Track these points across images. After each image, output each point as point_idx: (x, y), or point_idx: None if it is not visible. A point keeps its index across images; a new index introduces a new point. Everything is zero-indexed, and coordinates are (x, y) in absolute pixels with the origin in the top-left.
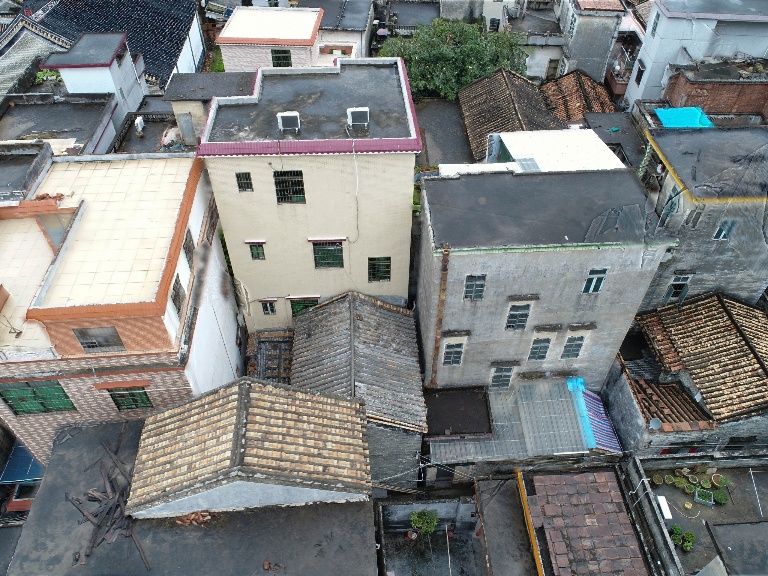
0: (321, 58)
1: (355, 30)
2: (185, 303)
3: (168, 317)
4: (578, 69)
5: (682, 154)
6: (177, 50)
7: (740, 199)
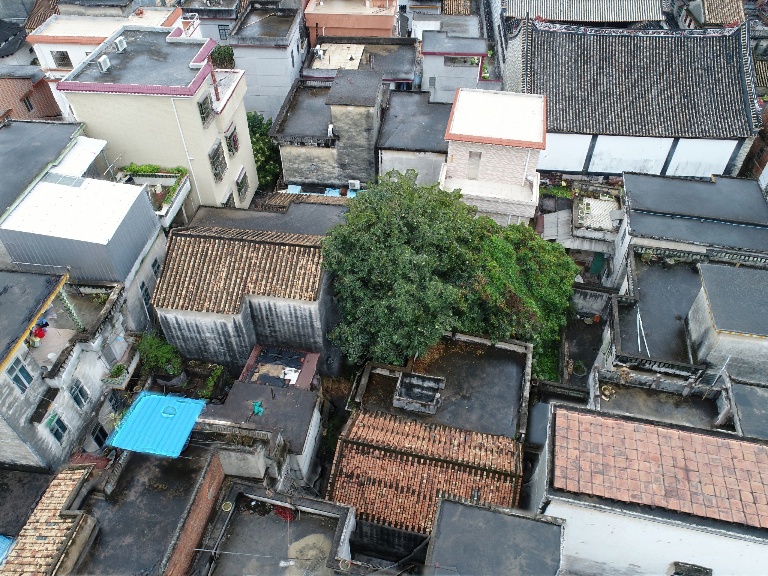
0: (520, 187)
1: None
2: (70, 69)
3: (37, 50)
4: (517, 476)
5: (6, 286)
6: (615, 130)
7: (7, 437)
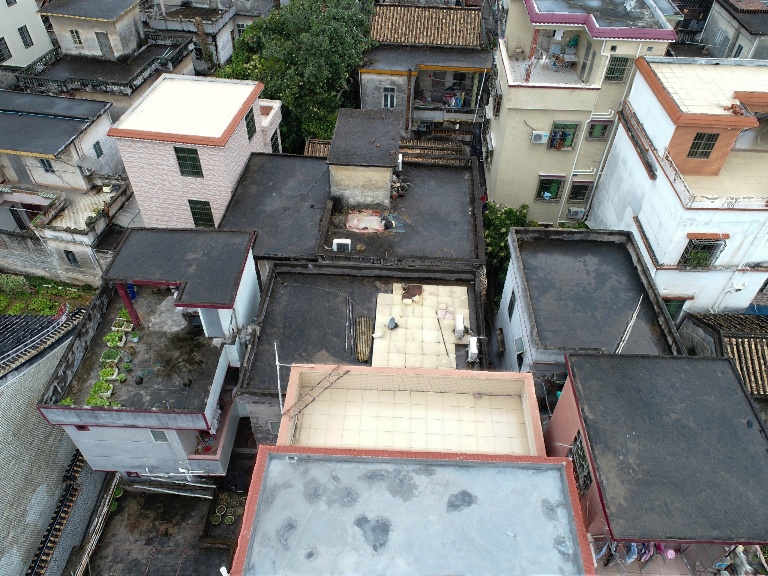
0: None
1: (105, 110)
2: None
3: None
4: None
5: None
6: None
7: None
